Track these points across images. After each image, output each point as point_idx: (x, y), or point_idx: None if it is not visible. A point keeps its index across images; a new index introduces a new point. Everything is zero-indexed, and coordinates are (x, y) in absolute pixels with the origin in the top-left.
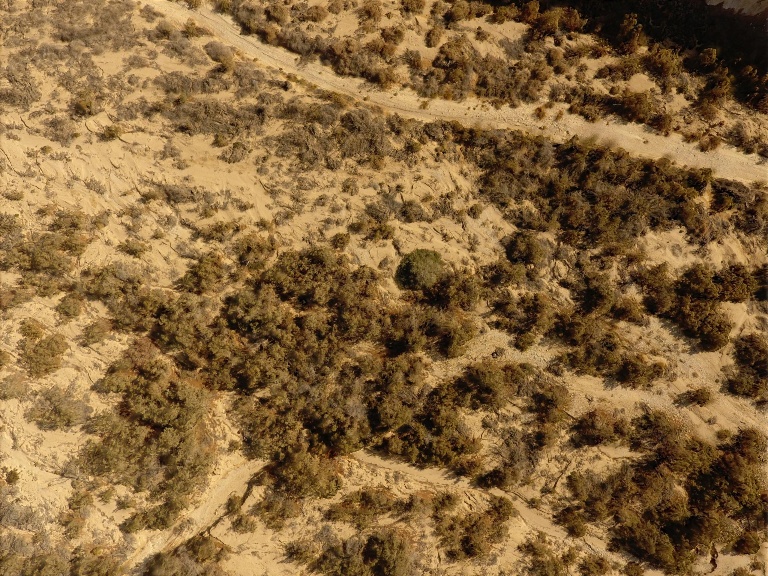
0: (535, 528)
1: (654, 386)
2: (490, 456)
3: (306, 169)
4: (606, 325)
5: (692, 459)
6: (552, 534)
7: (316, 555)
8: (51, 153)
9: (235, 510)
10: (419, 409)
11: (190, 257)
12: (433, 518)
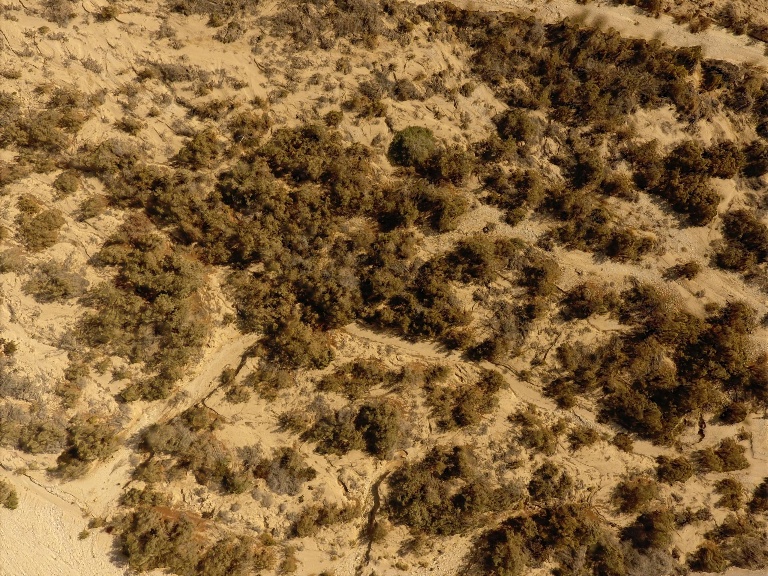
0: (525, 400)
1: (643, 260)
2: (481, 328)
3: (300, 49)
4: (596, 201)
5: (680, 329)
6: (542, 406)
7: (309, 425)
8: (48, 33)
9: (229, 381)
10: (411, 282)
11: (185, 134)
12: (424, 389)
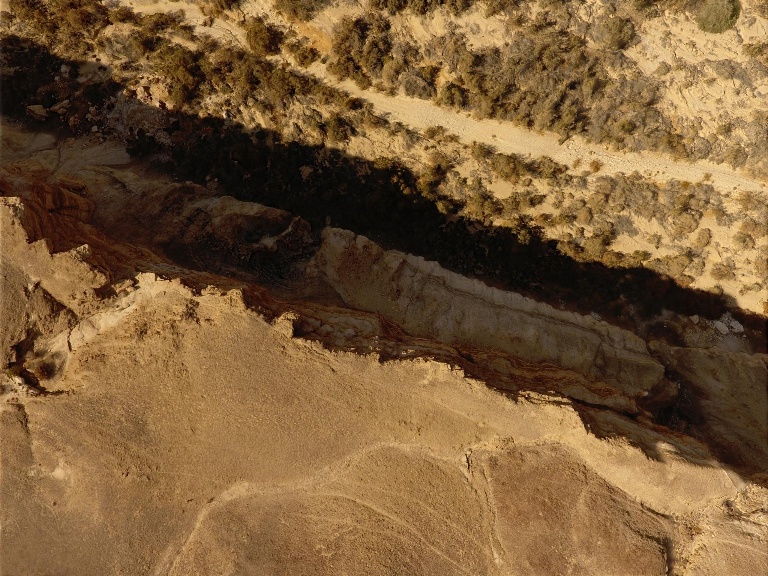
0: None
1: None
2: None
3: None
4: None
5: None
6: None
7: None
8: None
9: None
10: None
11: None
12: None
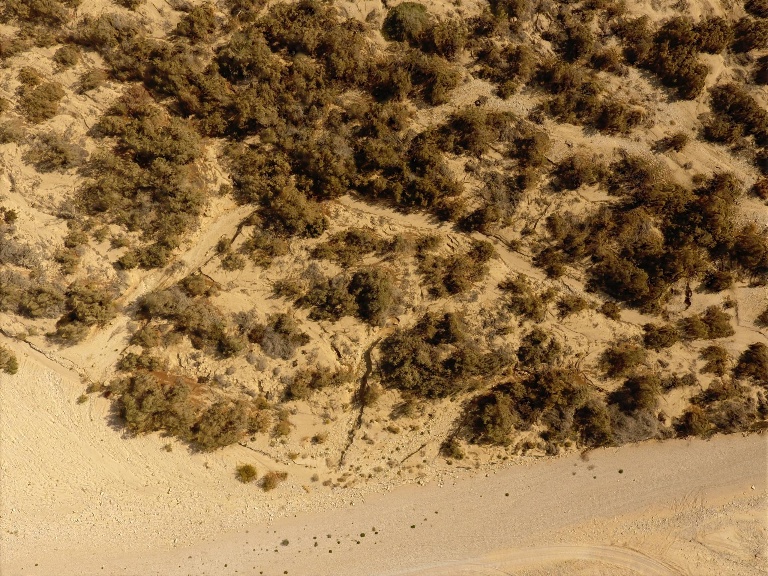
0: (515, 270)
1: (632, 133)
2: (472, 198)
3: None
4: (586, 76)
5: (668, 197)
6: (532, 276)
7: (303, 292)
8: None
9: (225, 249)
10: (404, 154)
11: (183, 9)
12: (416, 257)
